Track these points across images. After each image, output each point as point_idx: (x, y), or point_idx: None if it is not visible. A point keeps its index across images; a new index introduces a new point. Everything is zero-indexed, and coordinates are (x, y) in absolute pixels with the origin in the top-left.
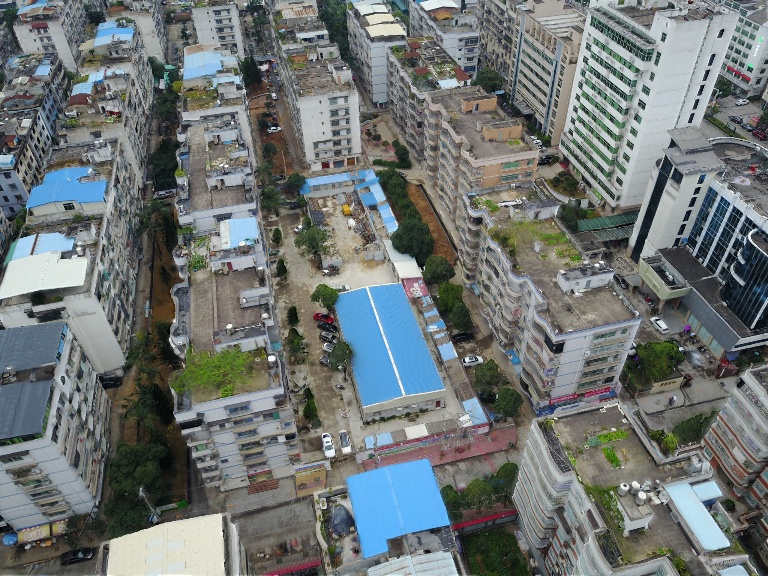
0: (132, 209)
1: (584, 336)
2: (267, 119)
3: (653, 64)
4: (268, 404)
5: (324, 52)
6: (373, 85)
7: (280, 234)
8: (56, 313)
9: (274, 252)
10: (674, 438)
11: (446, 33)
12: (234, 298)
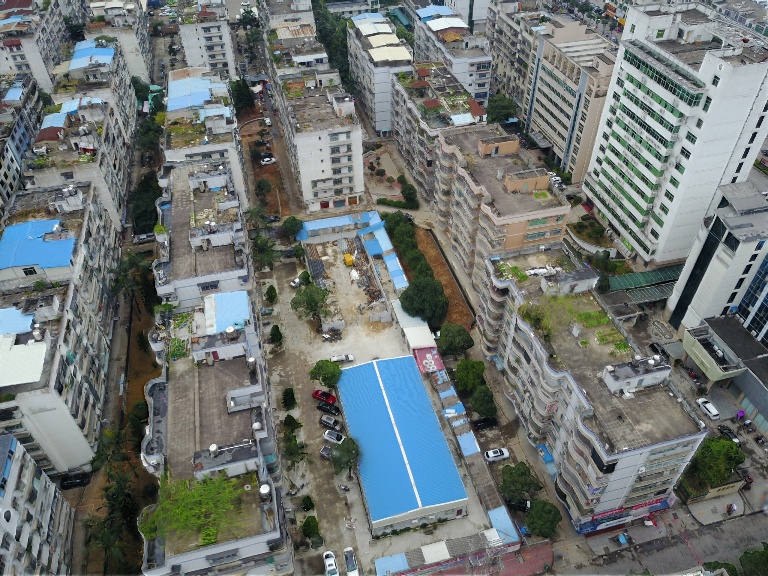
0: (107, 263)
1: (640, 453)
2: (260, 148)
3: (701, 110)
4: (260, 549)
5: (323, 79)
6: (376, 112)
7: (274, 292)
8: (7, 413)
9: (268, 312)
10: None
11: (456, 57)
12: (220, 399)
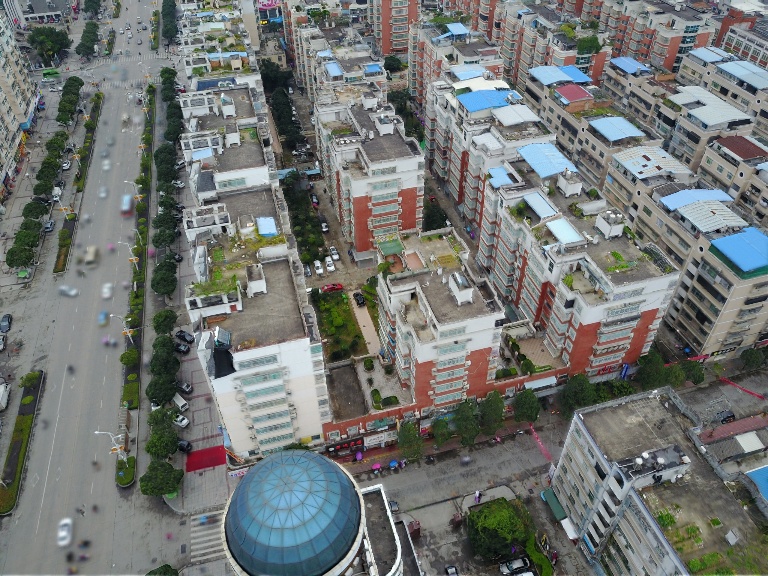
0: None
1: None
2: None
3: None
4: None
5: None
6: None
7: None
8: None
9: None
10: (569, 276)
11: None
12: None
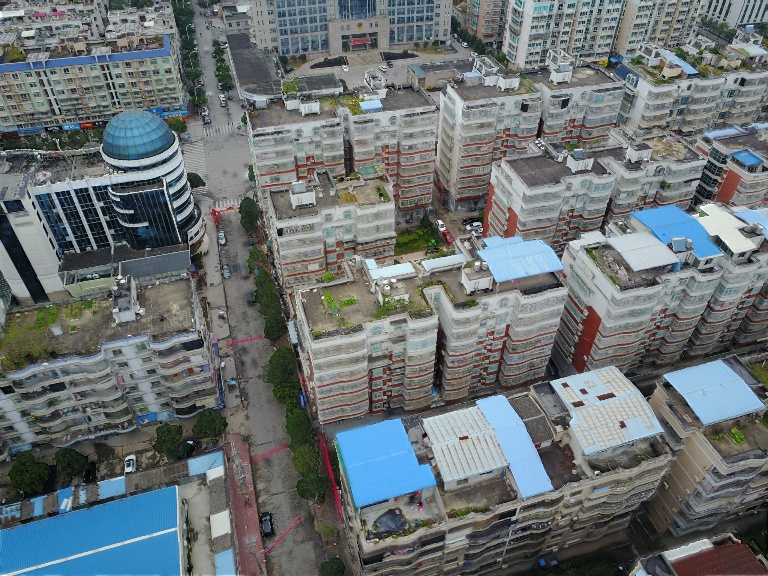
0: None
1: None
2: None
3: None
4: None
5: None
6: None
7: None
8: None
9: None
10: None
11: None
12: None
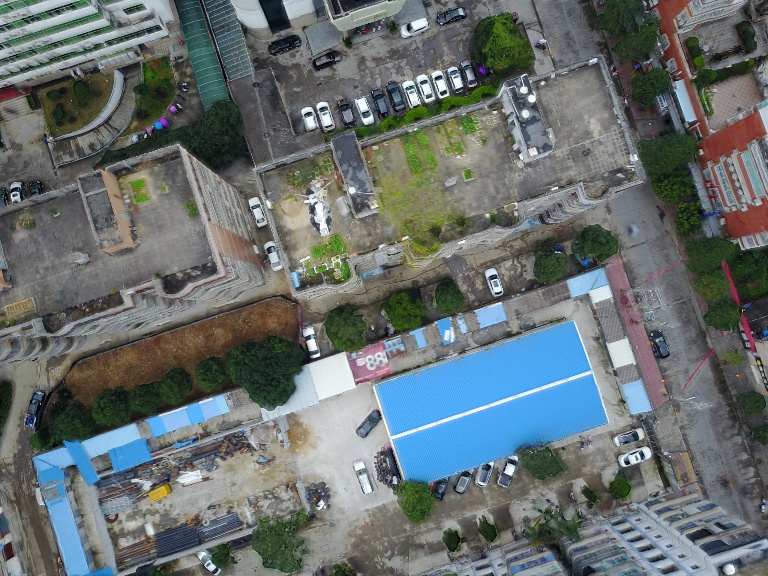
0: None
1: None
2: None
3: None
4: None
5: None
6: None
7: None
8: None
9: None
10: None
11: None
12: None
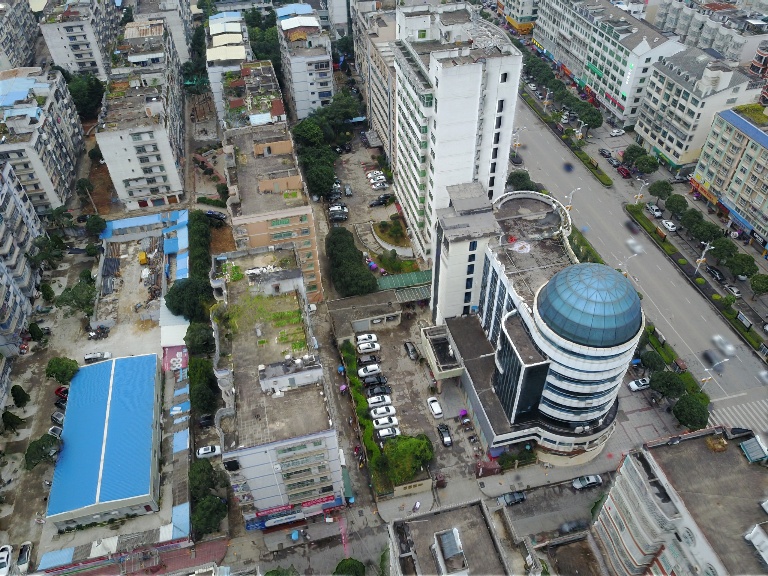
0: None
1: (263, 451)
2: None
3: (434, 110)
4: None
5: (147, 79)
6: (218, 112)
7: (49, 290)
8: None
9: (45, 309)
10: None
11: (293, 56)
12: None
